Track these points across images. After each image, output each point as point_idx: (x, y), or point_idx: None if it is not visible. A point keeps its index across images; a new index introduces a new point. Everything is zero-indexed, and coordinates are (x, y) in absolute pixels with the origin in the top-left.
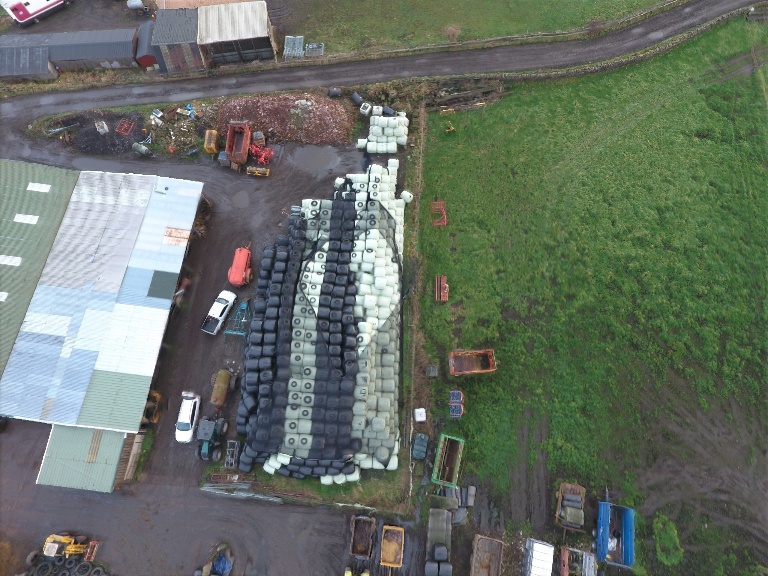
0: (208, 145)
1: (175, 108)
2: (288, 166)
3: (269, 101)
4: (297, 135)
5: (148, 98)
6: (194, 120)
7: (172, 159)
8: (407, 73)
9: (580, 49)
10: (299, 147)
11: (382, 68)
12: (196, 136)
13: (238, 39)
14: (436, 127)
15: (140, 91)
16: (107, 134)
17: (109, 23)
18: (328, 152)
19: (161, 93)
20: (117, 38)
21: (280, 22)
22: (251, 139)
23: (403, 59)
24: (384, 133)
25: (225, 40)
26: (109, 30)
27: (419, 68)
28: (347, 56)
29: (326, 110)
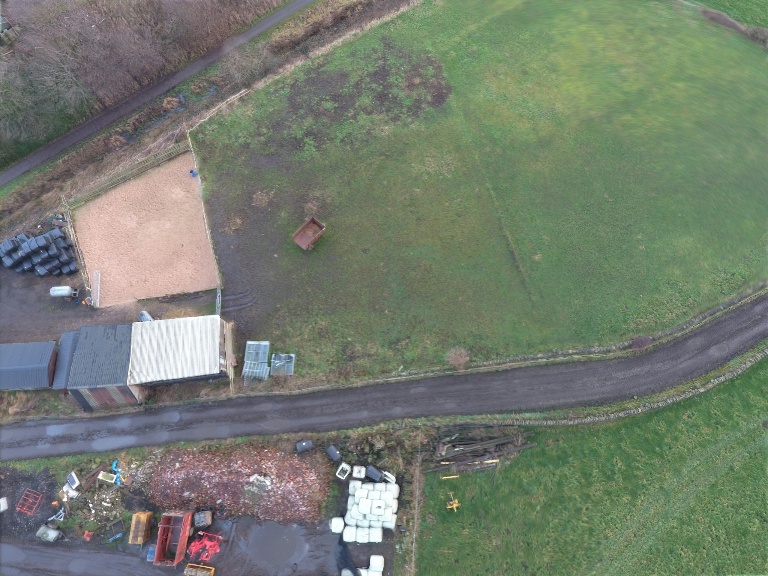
0: (134, 541)
1: (96, 472)
2: (240, 557)
3: (216, 474)
4: (253, 510)
5: (65, 444)
6: (120, 487)
7: (90, 543)
8: (399, 410)
9: (622, 373)
10: (256, 525)
11: (367, 401)
12: (122, 509)
13: (180, 377)
14: (434, 497)
15: (56, 432)
16: (6, 512)
17: (28, 313)
18: (293, 534)
19: (82, 436)
20: (29, 360)
21: (242, 316)
22: (192, 523)
23: (394, 387)
24: (366, 518)
25: (164, 379)
26: (21, 344)
27: (414, 402)
28: (322, 387)
29: (290, 488)
